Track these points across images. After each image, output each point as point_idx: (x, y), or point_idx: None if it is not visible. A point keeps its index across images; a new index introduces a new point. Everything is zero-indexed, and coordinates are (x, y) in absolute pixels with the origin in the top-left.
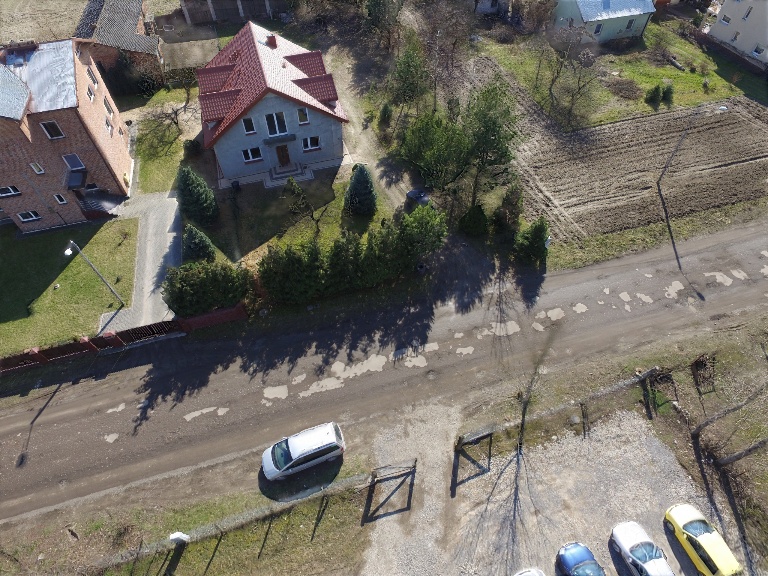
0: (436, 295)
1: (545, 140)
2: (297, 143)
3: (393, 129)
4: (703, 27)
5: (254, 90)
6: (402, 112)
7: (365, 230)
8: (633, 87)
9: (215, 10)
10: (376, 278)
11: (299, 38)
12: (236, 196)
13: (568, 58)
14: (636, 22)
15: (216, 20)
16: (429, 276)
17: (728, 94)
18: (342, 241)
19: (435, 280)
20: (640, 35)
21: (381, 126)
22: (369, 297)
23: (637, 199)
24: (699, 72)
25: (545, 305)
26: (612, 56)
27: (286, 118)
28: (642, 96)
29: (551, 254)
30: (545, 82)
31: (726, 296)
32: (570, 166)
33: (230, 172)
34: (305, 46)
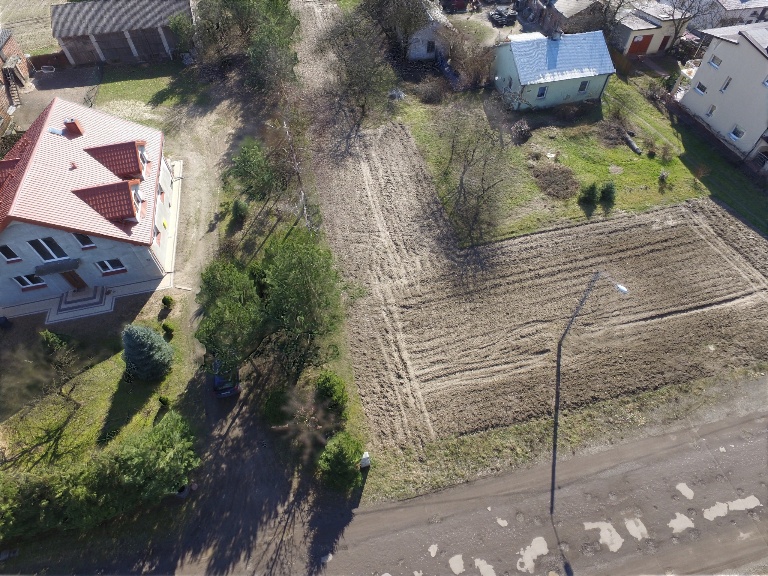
0: (189, 540)
1: (431, 260)
2: (88, 267)
3: (244, 233)
4: (676, 92)
5: (2, 212)
6: (265, 207)
7: (140, 408)
8: (567, 179)
9: (102, 49)
10: (94, 521)
11: (191, 88)
12: (2, 336)
13: (499, 130)
14: (591, 84)
15: (105, 60)
16: (192, 503)
17: (689, 194)
18: (25, 484)
19: (198, 510)
20: (597, 98)
21: (231, 228)
22: (94, 539)
23: (523, 372)
24: (659, 157)
25: (336, 573)
26: (554, 129)
27: (59, 243)
28: (576, 193)
29: (376, 469)
30: (459, 166)
31: (607, 573)
32: (450, 307)
33: (5, 299)
34: (193, 100)
